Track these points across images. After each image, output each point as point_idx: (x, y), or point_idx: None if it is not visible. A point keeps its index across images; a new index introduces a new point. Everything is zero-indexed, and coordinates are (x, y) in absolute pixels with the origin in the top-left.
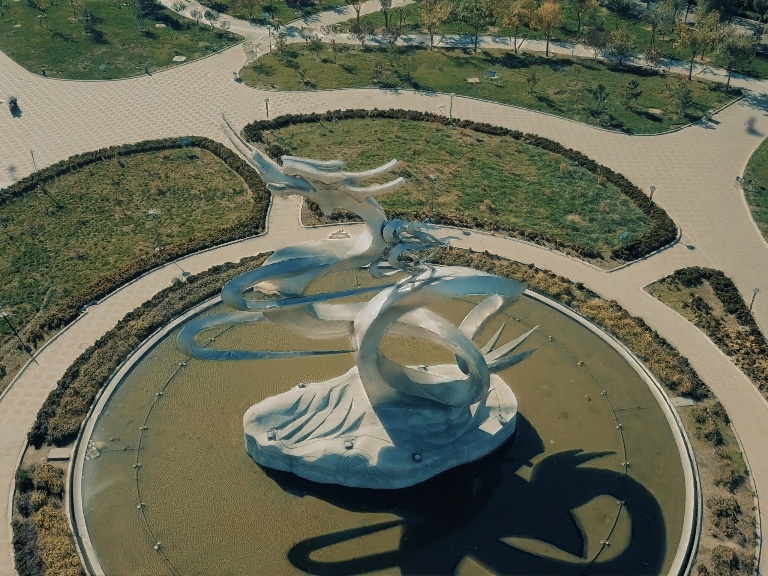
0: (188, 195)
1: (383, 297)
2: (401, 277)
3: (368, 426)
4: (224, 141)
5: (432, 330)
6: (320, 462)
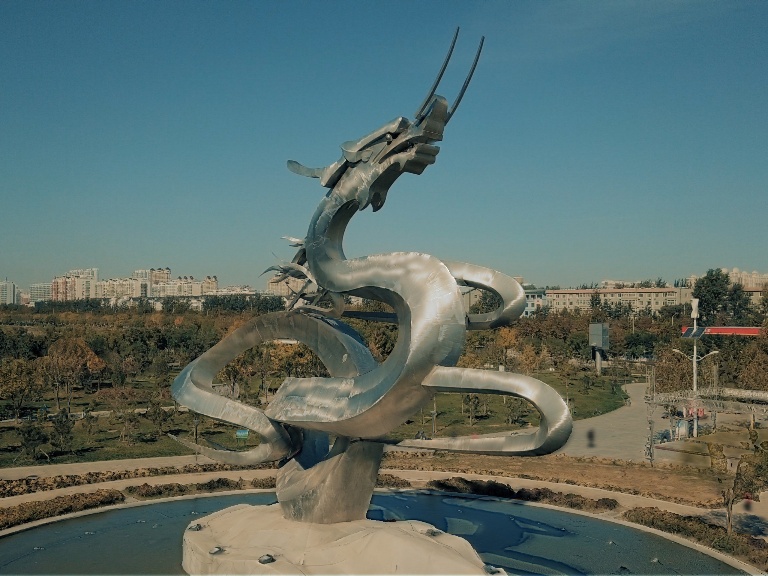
0: None
1: (346, 336)
2: None
3: None
4: None
5: None
6: None
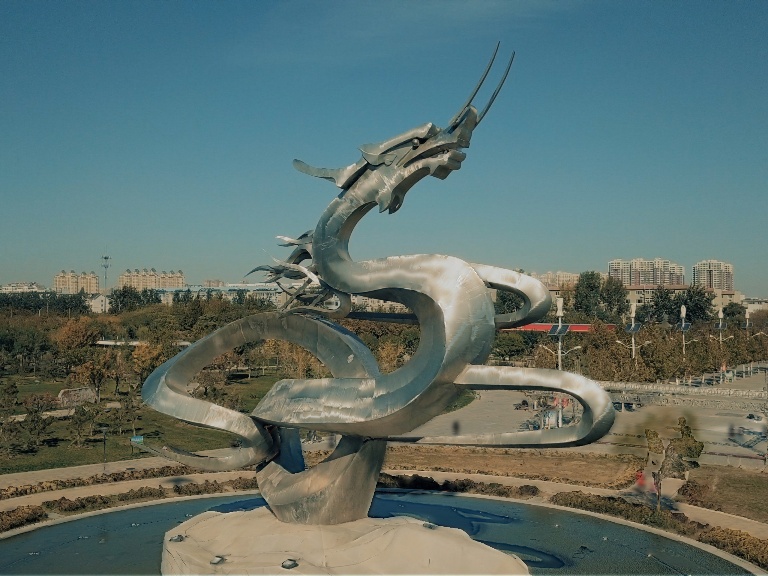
0: None
1: None
2: None
3: None
4: None
5: None
6: None
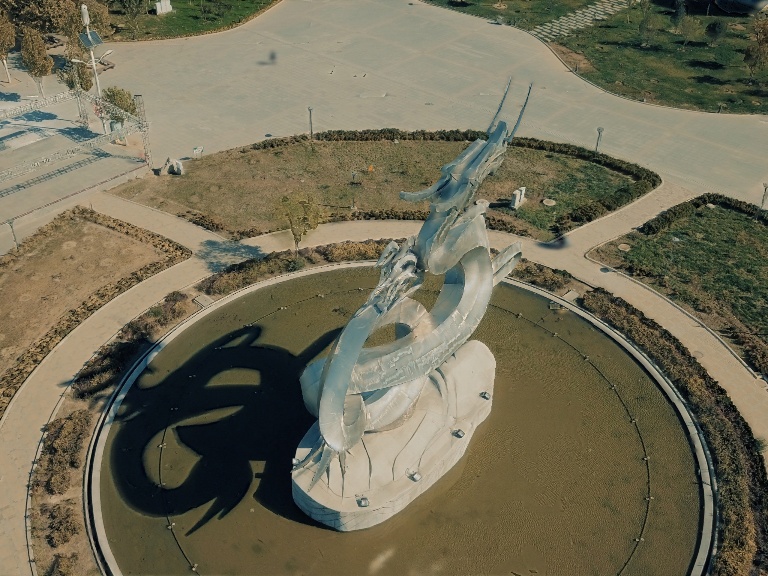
0: None
1: None
2: None
3: None
4: None
5: None
6: None
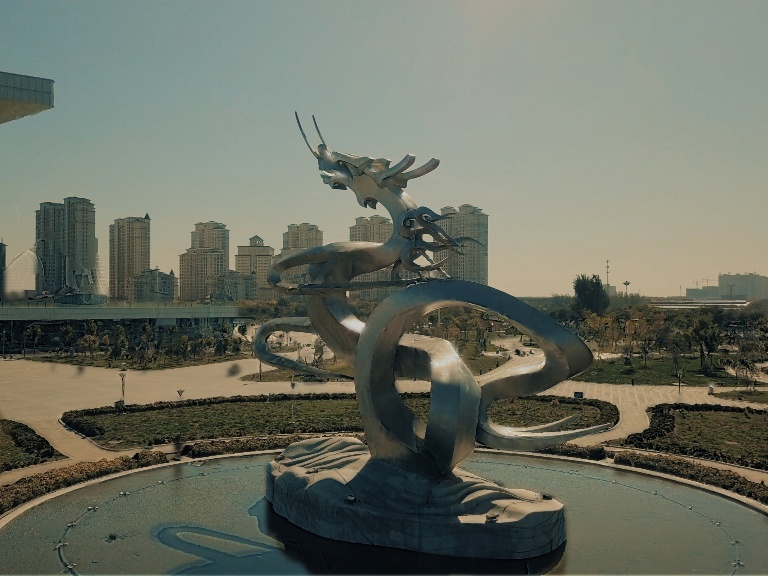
0: (531, 418)
1: None
2: (634, 479)
3: (348, 468)
4: (624, 408)
5: (428, 351)
6: (280, 480)
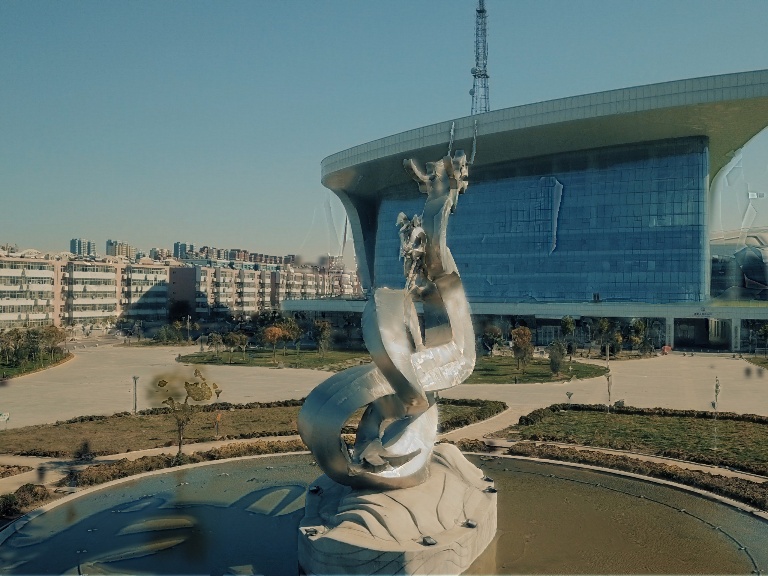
0: None
1: None
2: None
3: None
4: None
5: None
6: None
